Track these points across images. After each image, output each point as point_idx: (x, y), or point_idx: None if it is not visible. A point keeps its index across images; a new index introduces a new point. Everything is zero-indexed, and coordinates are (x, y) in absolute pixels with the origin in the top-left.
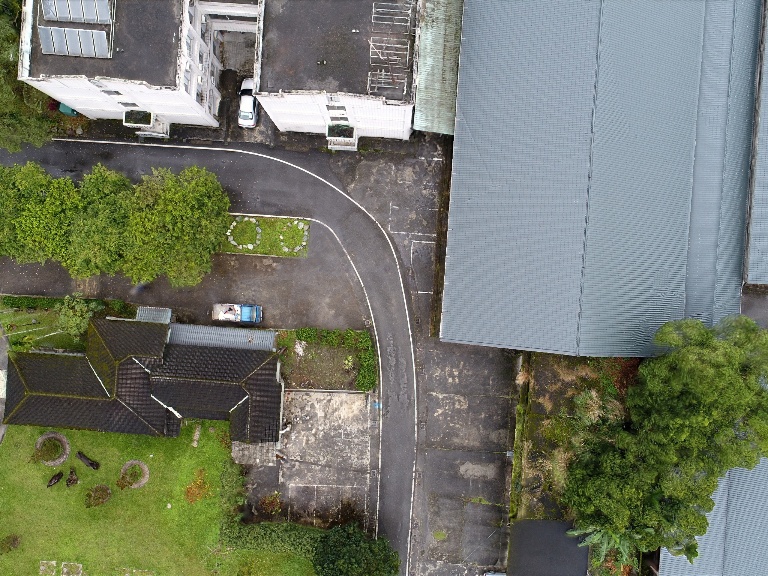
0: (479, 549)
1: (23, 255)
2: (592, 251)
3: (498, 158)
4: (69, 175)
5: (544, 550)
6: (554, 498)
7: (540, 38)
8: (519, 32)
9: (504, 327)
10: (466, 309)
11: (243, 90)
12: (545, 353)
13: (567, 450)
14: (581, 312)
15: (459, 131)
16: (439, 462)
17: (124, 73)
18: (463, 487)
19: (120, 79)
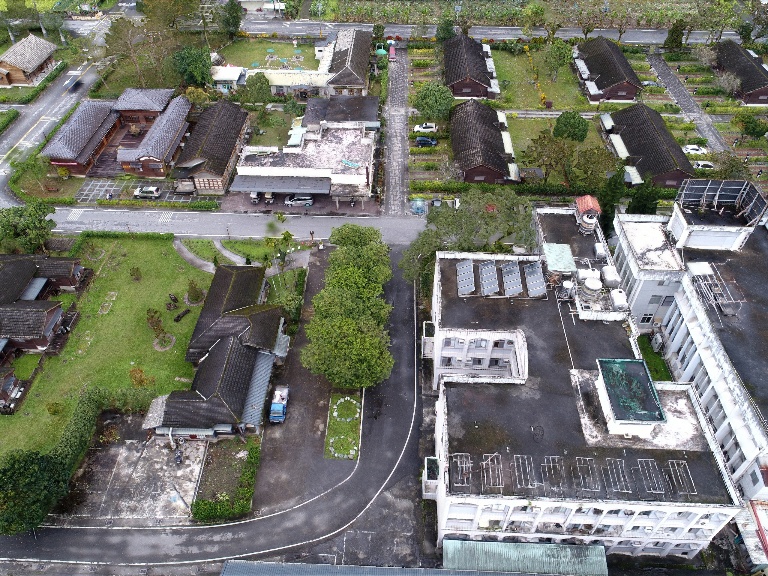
0: None
1: (330, 271)
2: None
3: None
4: (390, 303)
5: None
6: None
7: None
8: None
9: None
10: None
11: None
12: None
13: None
14: None
15: (440, 574)
16: None
17: (450, 303)
18: None
19: None
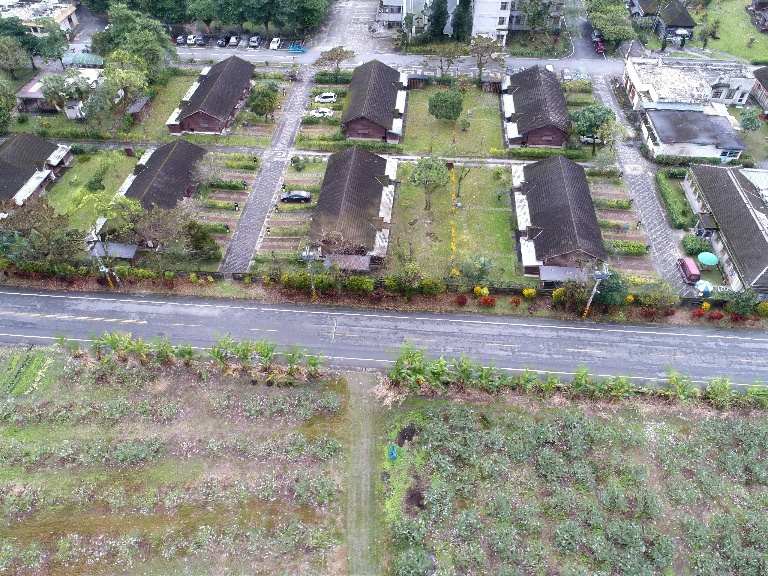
0: None
1: None
2: None
3: None
4: None
5: None
6: None
7: None
8: None
9: None
10: None
11: None
12: None
13: None
14: None
15: None
16: None
17: None
18: None
19: None
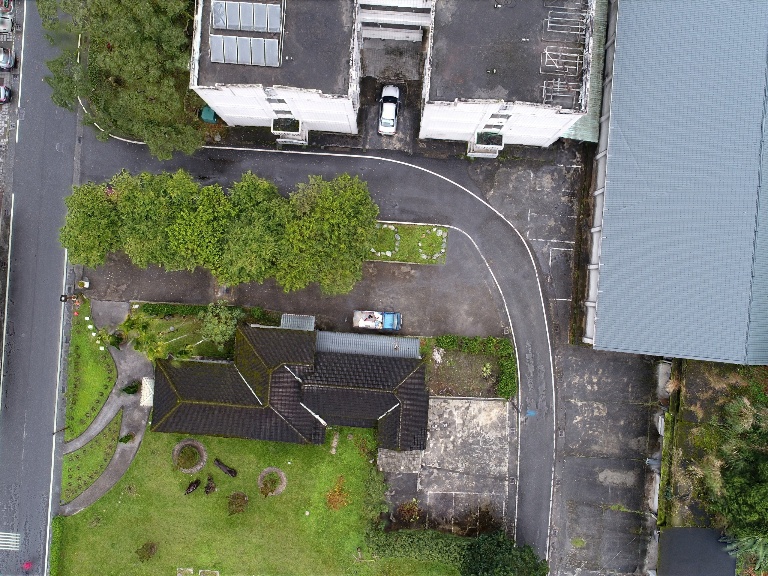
0: (618, 556)
1: (172, 263)
2: (760, 260)
3: (657, 166)
4: (207, 182)
5: (693, 558)
6: (703, 506)
7: (703, 46)
8: (679, 40)
9: (664, 335)
10: (622, 317)
11: (384, 97)
12: (696, 361)
13: (716, 458)
14: (750, 321)
15: (613, 139)
16: (578, 469)
17: (293, 81)
18: (602, 494)
19: (296, 88)
